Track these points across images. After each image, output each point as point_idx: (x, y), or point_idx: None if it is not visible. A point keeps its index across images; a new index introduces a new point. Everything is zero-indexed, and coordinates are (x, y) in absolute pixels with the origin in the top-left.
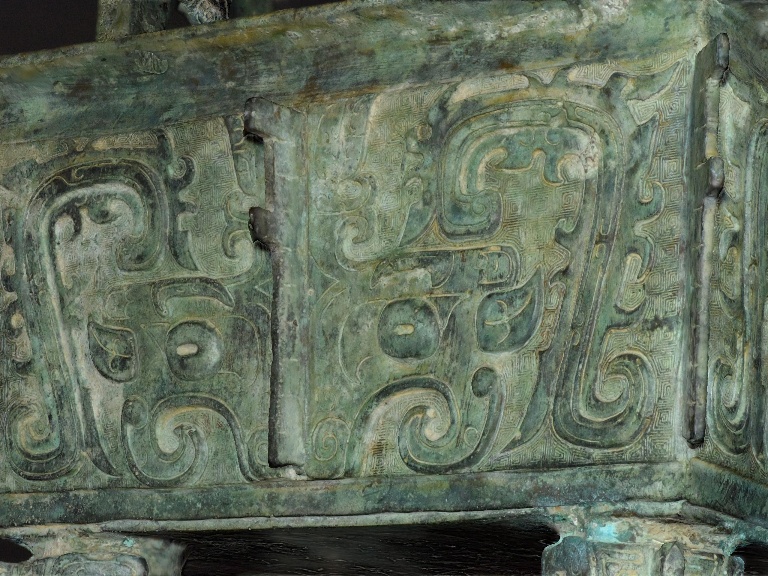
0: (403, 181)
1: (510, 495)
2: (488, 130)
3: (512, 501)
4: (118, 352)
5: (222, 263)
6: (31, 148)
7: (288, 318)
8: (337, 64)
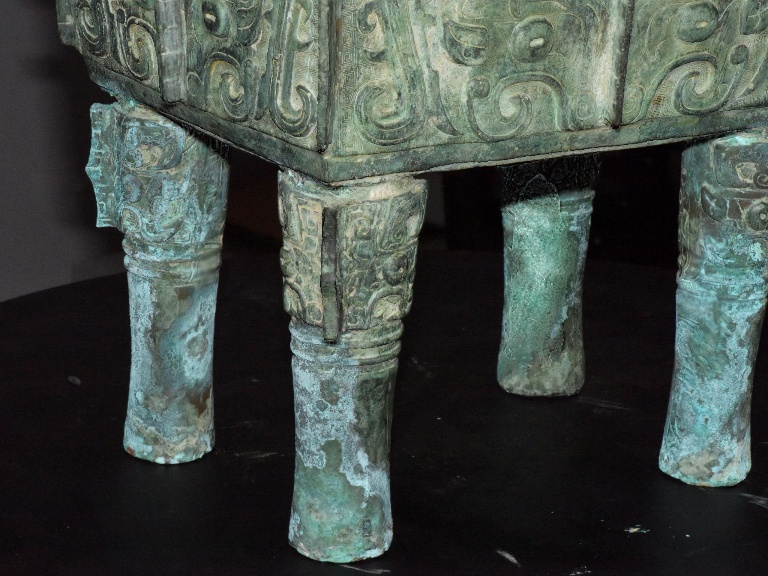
0: None
1: None
2: None
3: (737, 126)
4: (471, 44)
5: None
6: None
7: None
8: None
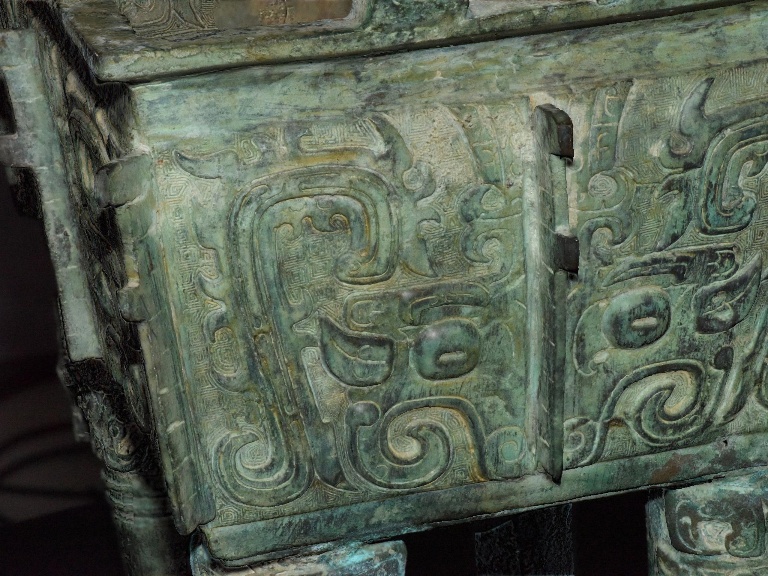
0: None
1: None
2: None
3: None
4: None
5: None
6: None
7: (57, 231)
8: None
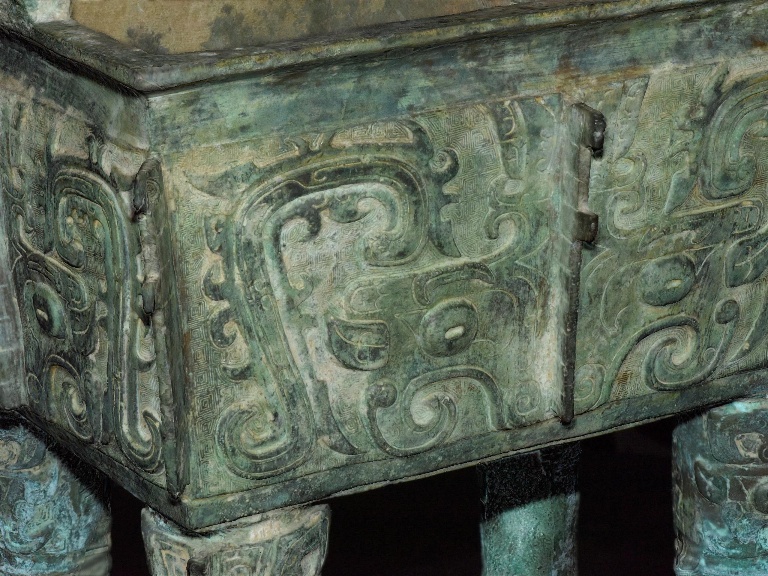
0: (670, 154)
1: (730, 391)
2: (756, 107)
3: (731, 395)
4: (366, 343)
5: (482, 245)
6: (245, 150)
7: None
8: (590, 42)
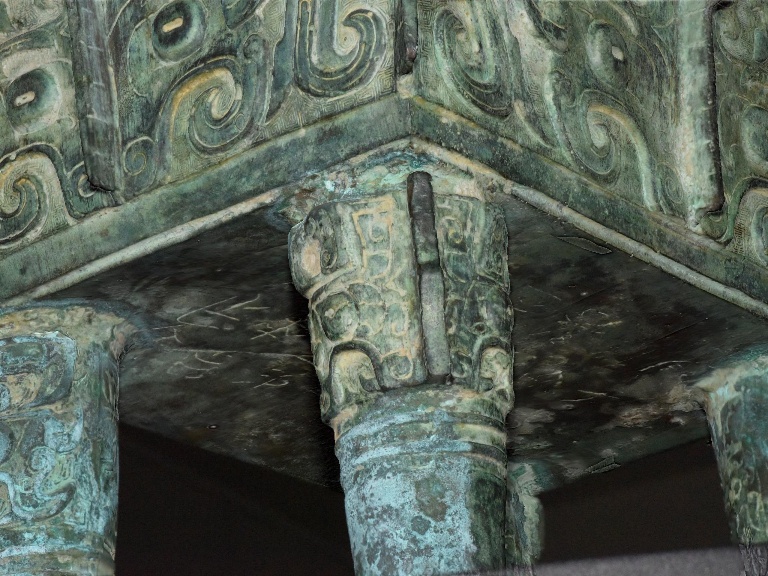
0: (750, 5)
1: None
2: None
3: None
4: (549, 16)
5: None
6: None
7: None
8: None
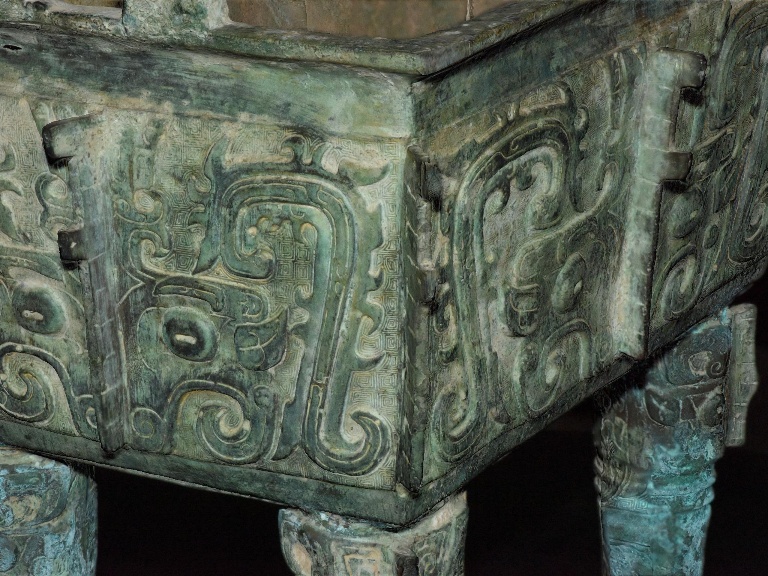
0: None
1: None
2: None
3: None
4: None
5: None
6: None
7: None
8: None
